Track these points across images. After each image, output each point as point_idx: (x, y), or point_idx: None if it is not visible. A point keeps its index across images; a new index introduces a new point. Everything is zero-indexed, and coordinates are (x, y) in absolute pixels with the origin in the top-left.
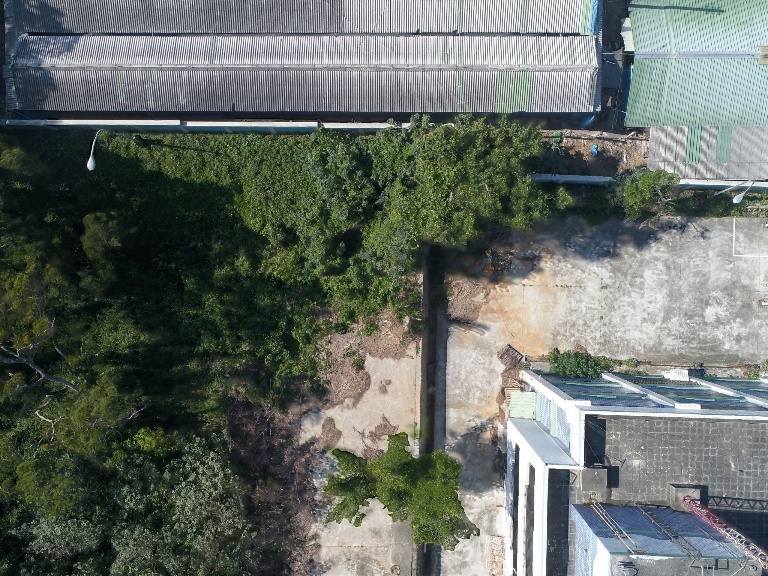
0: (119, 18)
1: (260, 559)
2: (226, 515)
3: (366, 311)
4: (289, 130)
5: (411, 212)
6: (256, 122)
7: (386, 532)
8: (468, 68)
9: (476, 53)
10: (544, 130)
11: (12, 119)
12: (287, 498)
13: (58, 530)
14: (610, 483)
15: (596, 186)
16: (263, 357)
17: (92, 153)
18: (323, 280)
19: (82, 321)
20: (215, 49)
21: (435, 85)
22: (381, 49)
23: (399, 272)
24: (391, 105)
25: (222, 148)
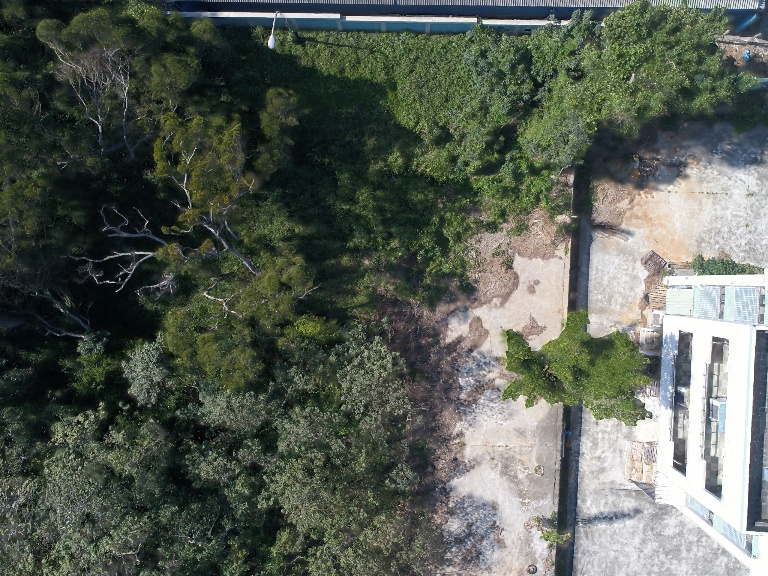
0: None
1: (406, 455)
2: (396, 395)
3: (518, 209)
4: (443, 29)
5: (586, 97)
6: (415, 17)
7: (531, 432)
8: None
9: None
10: None
11: (172, 11)
12: (432, 396)
13: (236, 402)
14: None
15: (748, 90)
16: (416, 252)
17: (273, 31)
18: (474, 179)
19: None
20: None
21: None
22: None
23: None
24: None
25: (376, 46)
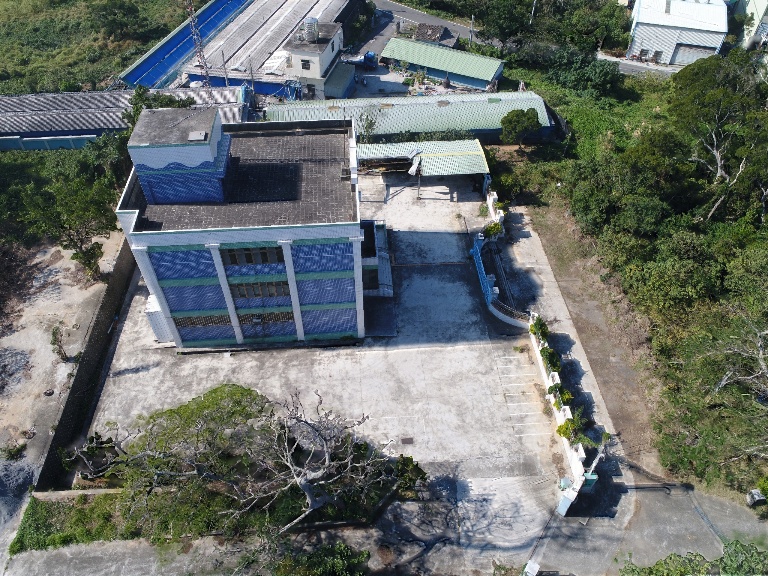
0: (5, 107)
1: None
2: None
3: None
4: None
5: None
6: None
7: (77, 305)
8: None
9: None
10: None
11: None
12: (9, 292)
13: None
14: None
15: None
16: None
17: None
18: None
19: None
20: None
21: None
22: None
23: (115, 157)
24: None
25: None
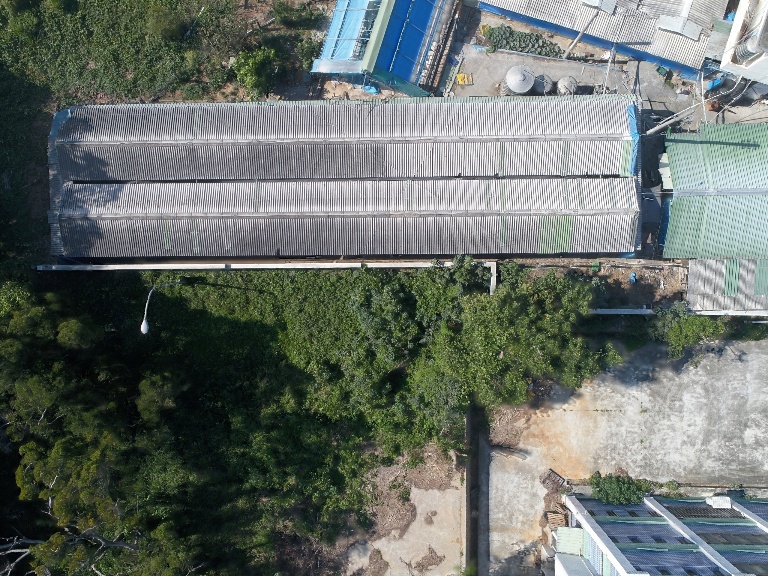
0: (164, 166)
1: None
2: None
3: (411, 445)
4: None
5: (461, 366)
6: (300, 263)
7: None
8: (511, 213)
9: (518, 197)
10: (582, 259)
11: (58, 264)
12: None
13: None
14: None
15: (635, 315)
16: (311, 494)
17: (145, 316)
18: (368, 414)
19: (131, 463)
20: (259, 196)
21: (478, 229)
22: (424, 194)
23: None
24: (434, 248)
25: (265, 285)
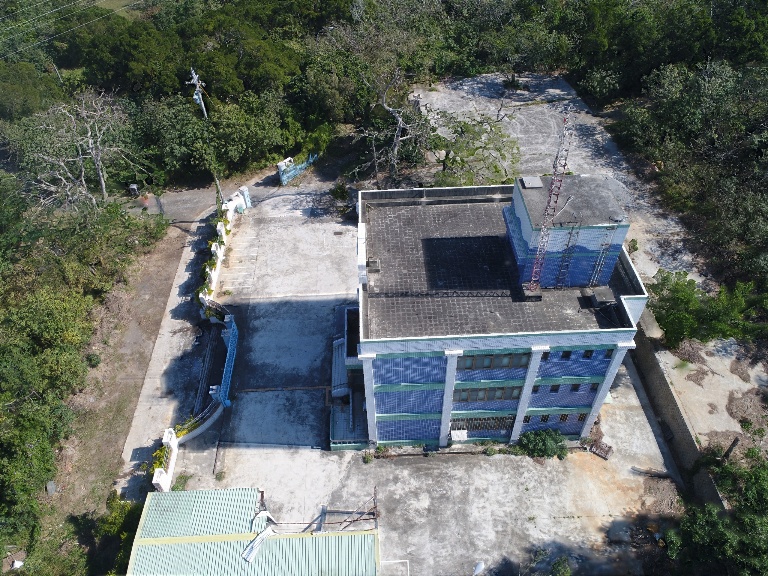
0: None
1: None
2: None
3: (767, 467)
4: None
5: None
6: None
7: None
8: None
9: None
10: None
11: None
12: None
13: None
14: (584, 299)
15: None
16: None
17: None
18: None
19: None
20: None
21: None
22: None
23: None
24: None
25: None
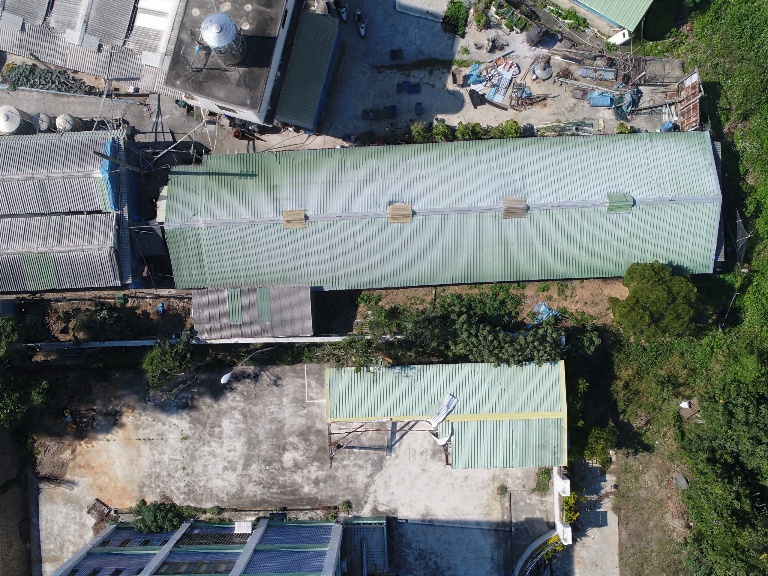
0: None
1: None
2: None
3: None
4: None
5: None
6: None
7: None
8: None
9: None
10: (112, 291)
11: None
12: None
13: None
14: None
15: None
16: None
17: None
18: None
19: None
20: None
21: None
22: None
23: None
24: None
25: None
